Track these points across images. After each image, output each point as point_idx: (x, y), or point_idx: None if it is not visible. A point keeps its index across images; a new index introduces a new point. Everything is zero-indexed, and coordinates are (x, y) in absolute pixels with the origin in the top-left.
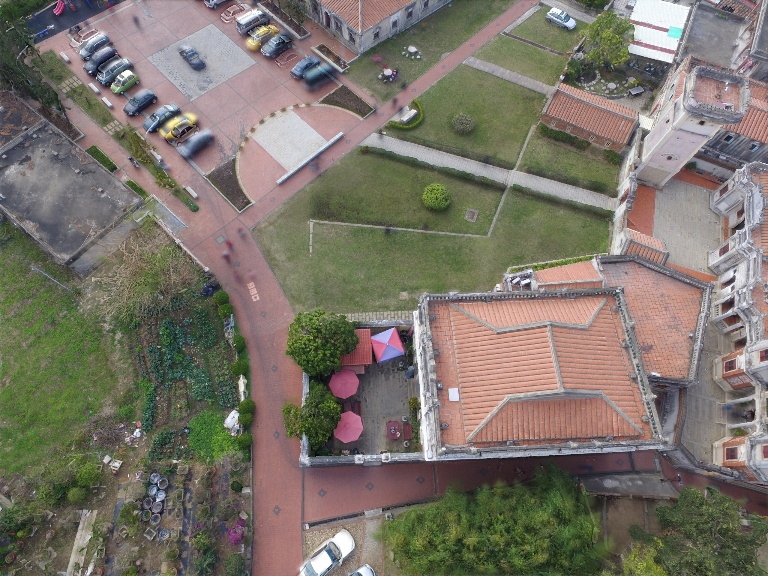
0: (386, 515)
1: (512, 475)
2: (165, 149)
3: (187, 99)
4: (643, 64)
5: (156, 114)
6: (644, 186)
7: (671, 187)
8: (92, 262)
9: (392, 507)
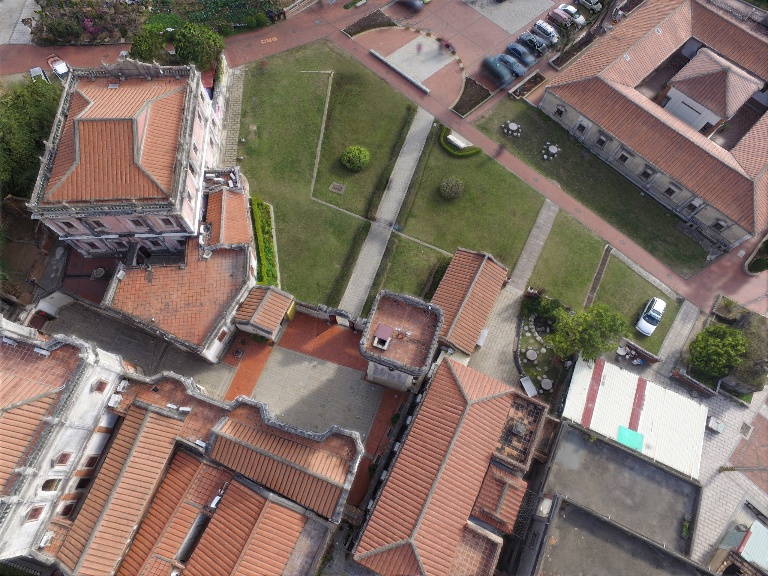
0: None
1: None
2: None
3: None
4: None
5: None
6: None
7: (369, 392)
8: None
9: None
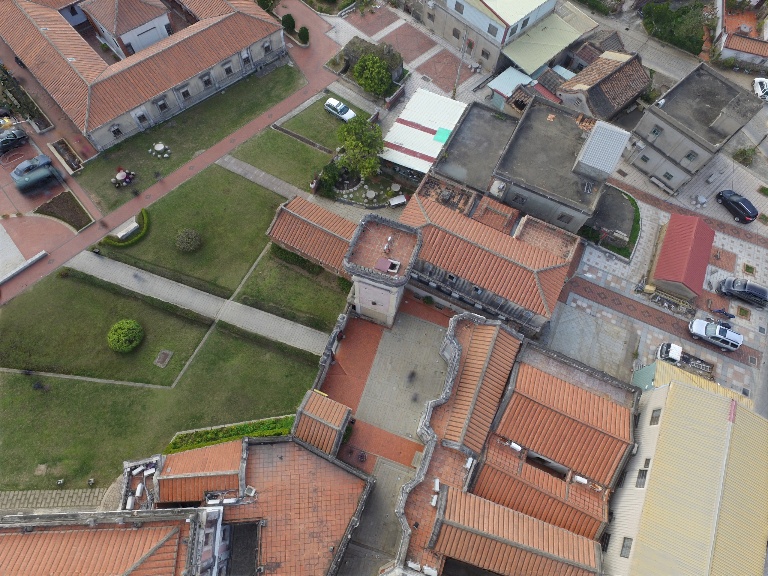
0: None
1: None
2: None
3: None
4: (405, 171)
5: None
6: (372, 323)
7: (402, 325)
8: None
9: None
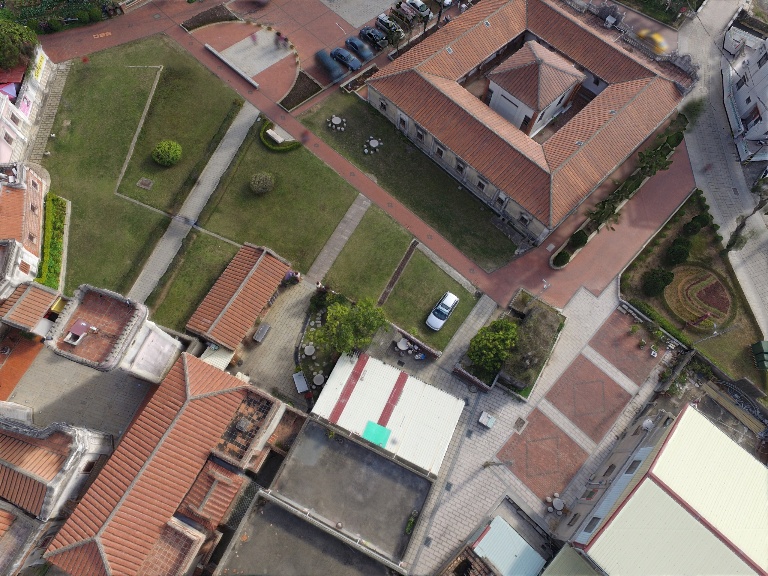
0: None
1: None
2: None
3: None
4: None
5: None
6: None
7: (134, 388)
8: None
9: None
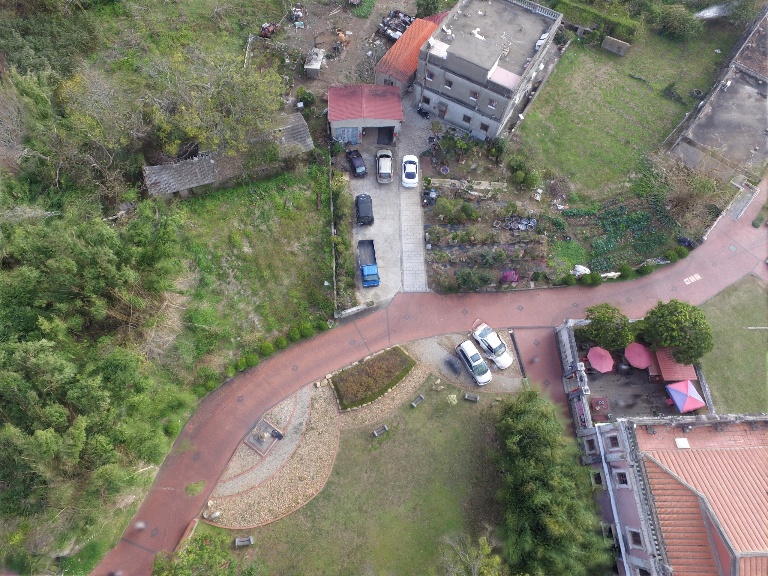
0: None
1: None
2: None
3: None
4: None
5: None
6: None
7: None
8: (683, 157)
9: None
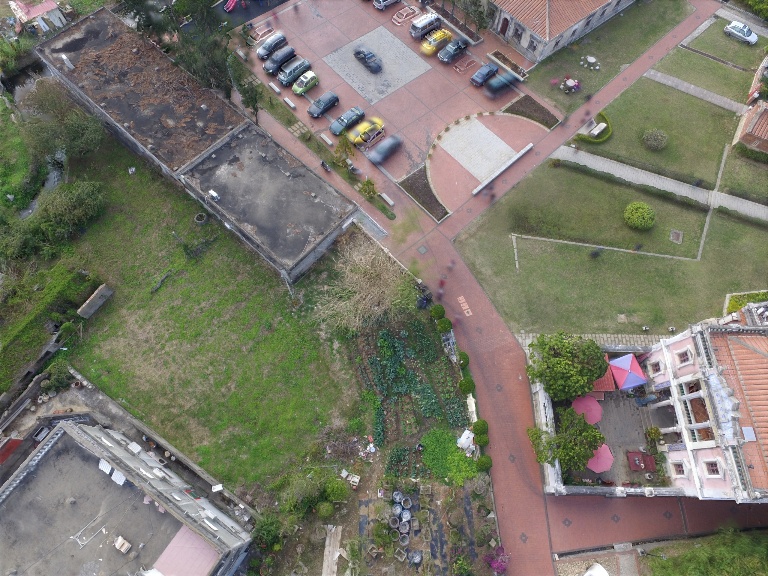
0: (639, 551)
1: (767, 517)
2: (352, 153)
3: (367, 102)
4: None
5: (344, 117)
6: None
7: None
8: (301, 267)
9: (641, 542)
